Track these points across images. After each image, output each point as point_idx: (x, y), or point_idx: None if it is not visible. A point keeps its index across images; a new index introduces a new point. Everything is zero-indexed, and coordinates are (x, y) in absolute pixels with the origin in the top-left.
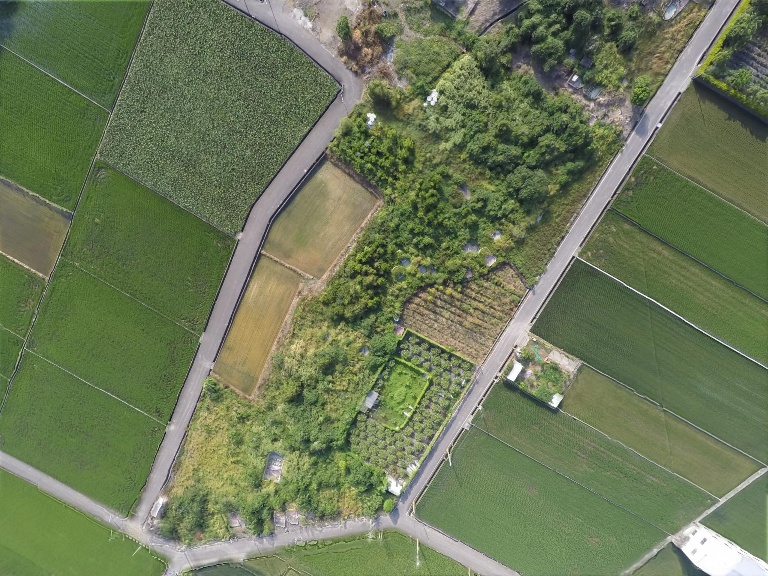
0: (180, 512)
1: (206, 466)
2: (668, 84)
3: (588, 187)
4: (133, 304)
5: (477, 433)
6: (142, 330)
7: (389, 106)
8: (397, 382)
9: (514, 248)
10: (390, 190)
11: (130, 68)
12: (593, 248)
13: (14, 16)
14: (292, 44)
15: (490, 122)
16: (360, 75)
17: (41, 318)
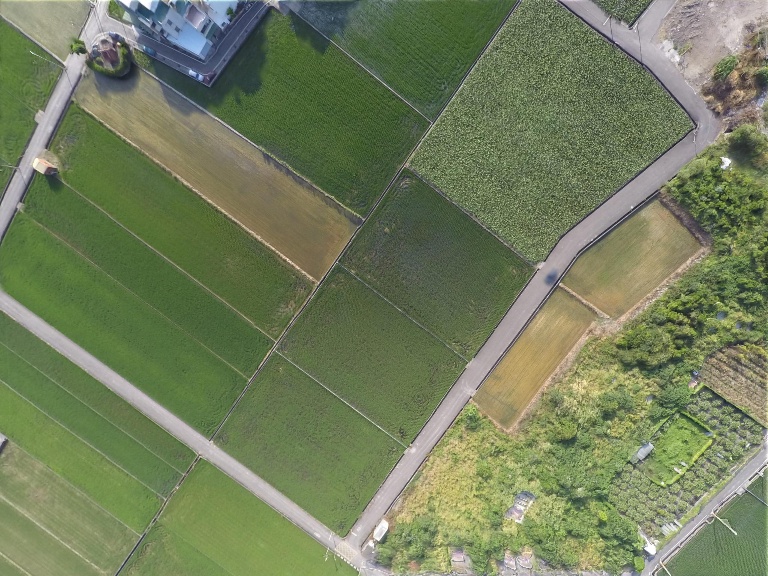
0: (409, 540)
1: (444, 495)
2: None
3: None
4: (403, 320)
5: (749, 500)
6: (405, 347)
7: (748, 153)
8: (673, 436)
9: None
10: (730, 240)
11: (466, 80)
12: None
13: (353, 12)
14: (652, 76)
15: None
16: (720, 117)
17: (300, 321)
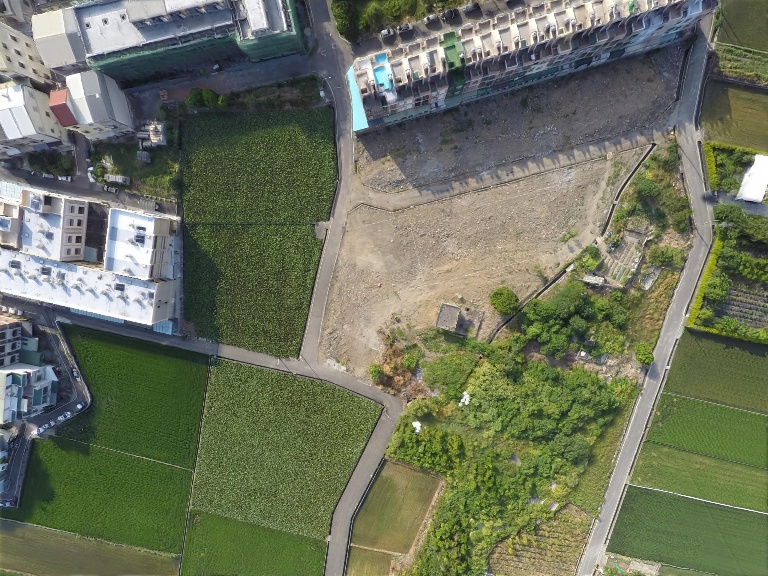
0: None
1: None
2: (665, 335)
3: (621, 428)
4: None
5: None
6: None
7: (430, 414)
8: None
9: (571, 491)
10: (451, 479)
11: (201, 435)
12: (641, 474)
13: (94, 421)
14: (333, 385)
15: (521, 408)
16: (397, 394)
17: None
